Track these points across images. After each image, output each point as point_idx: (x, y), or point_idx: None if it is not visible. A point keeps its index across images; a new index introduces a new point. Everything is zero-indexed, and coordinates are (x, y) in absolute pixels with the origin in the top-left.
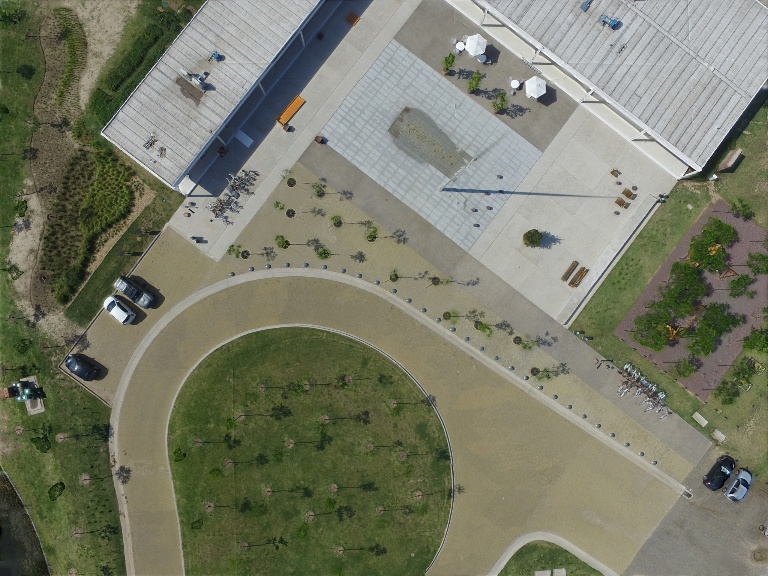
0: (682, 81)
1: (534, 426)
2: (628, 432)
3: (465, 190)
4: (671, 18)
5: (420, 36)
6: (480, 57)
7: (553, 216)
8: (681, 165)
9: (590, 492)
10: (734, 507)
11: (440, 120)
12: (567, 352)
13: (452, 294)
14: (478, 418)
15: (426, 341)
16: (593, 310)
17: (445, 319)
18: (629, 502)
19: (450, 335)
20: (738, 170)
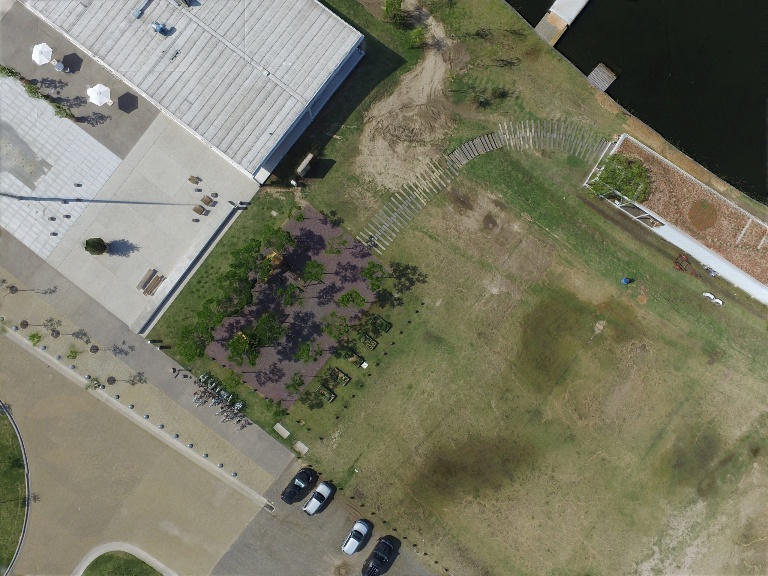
0: (236, 86)
1: (111, 436)
2: (207, 443)
3: (44, 199)
4: (227, 23)
5: (4, 46)
6: (57, 66)
7: (132, 224)
8: (262, 171)
9: (167, 503)
10: (318, 521)
11: (21, 129)
12: (144, 361)
13: (29, 303)
14: (54, 427)
15: (3, 350)
16: (171, 319)
17: (22, 328)
18: (208, 514)
19: (27, 344)
20: (328, 176)
